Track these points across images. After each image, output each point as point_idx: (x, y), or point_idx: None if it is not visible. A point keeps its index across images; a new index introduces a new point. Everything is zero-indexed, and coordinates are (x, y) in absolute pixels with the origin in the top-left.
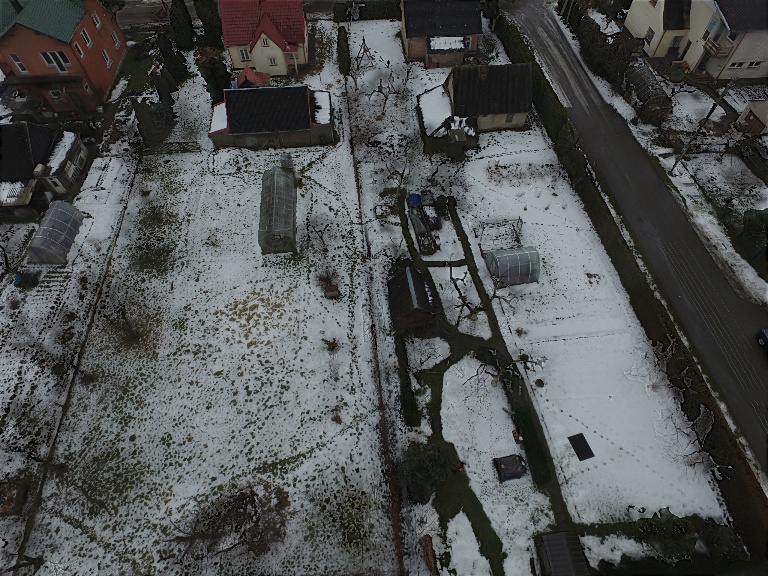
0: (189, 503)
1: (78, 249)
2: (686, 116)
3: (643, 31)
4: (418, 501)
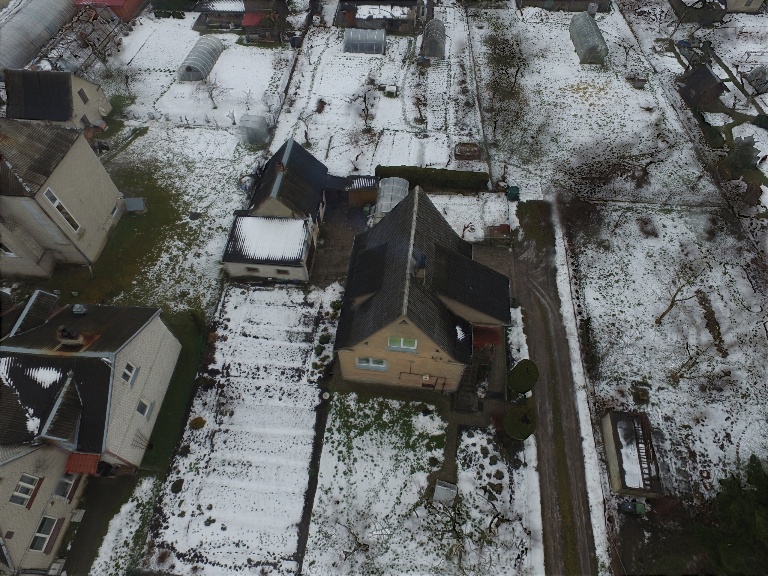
0: (583, 166)
1: (448, 51)
2: None
3: None
4: (732, 179)
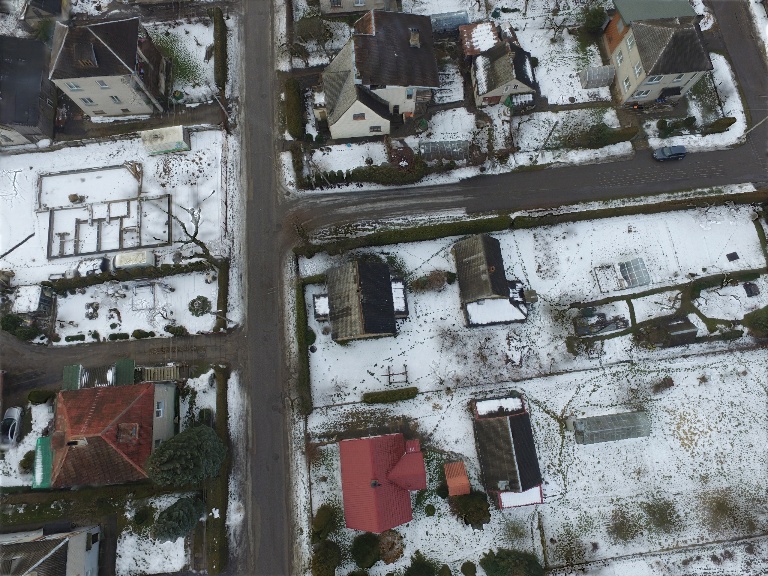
0: None
1: None
2: (471, 134)
3: (365, 131)
4: None
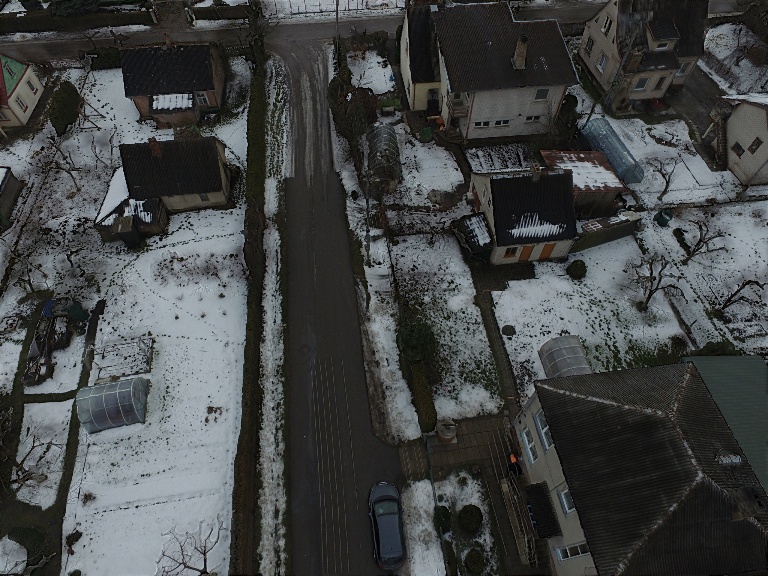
0: None
1: None
2: (417, 186)
3: (406, 80)
4: None
